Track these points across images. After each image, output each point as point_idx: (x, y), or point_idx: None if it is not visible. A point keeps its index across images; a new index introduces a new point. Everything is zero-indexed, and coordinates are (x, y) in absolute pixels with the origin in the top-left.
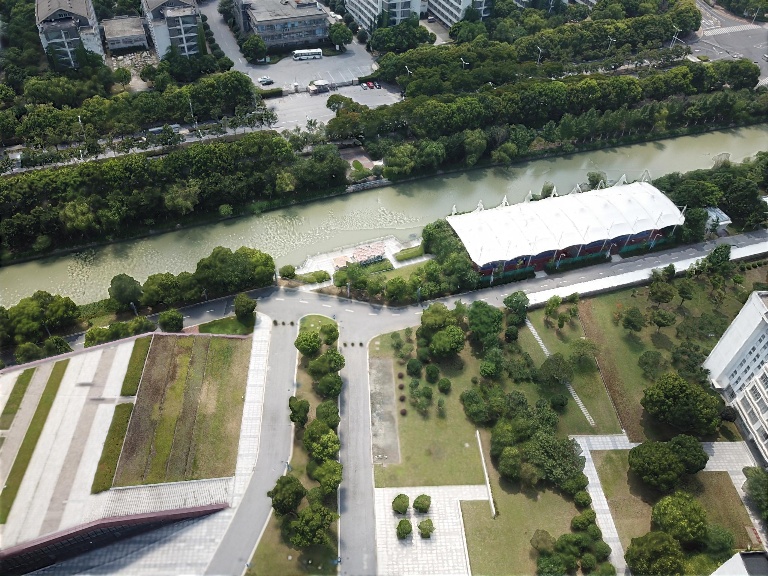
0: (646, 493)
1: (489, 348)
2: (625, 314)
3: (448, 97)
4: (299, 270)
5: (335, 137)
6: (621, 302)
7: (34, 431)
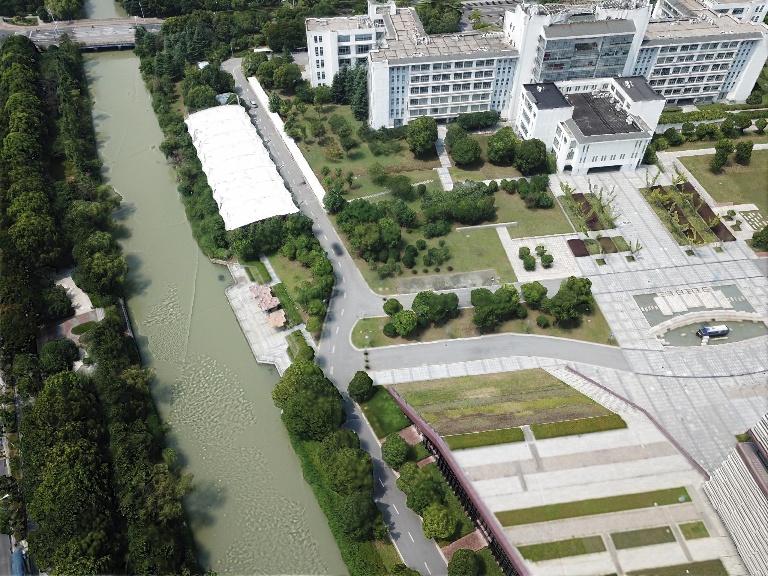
0: (477, 165)
1: (386, 215)
2: (333, 154)
3: (2, 218)
4: (279, 365)
5: (28, 343)
6: (316, 157)
7: (593, 506)
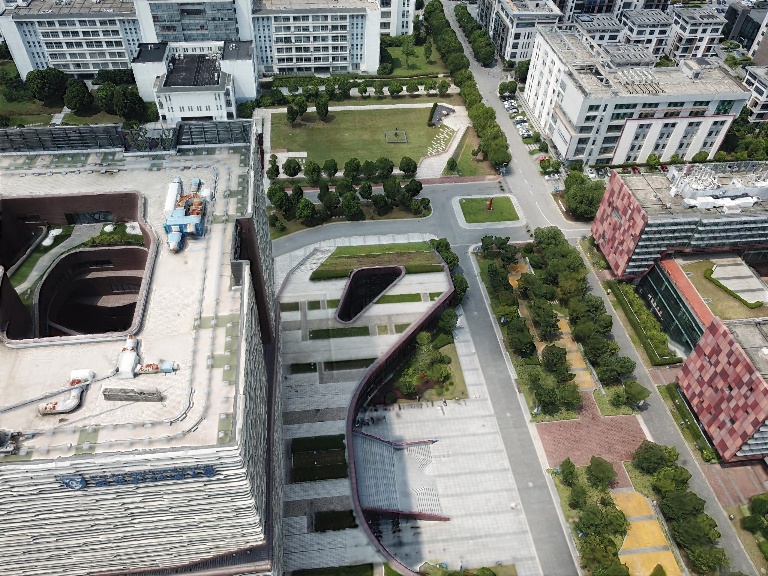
0: (92, 113)
1: None
2: None
3: None
4: None
5: None
6: None
7: None
